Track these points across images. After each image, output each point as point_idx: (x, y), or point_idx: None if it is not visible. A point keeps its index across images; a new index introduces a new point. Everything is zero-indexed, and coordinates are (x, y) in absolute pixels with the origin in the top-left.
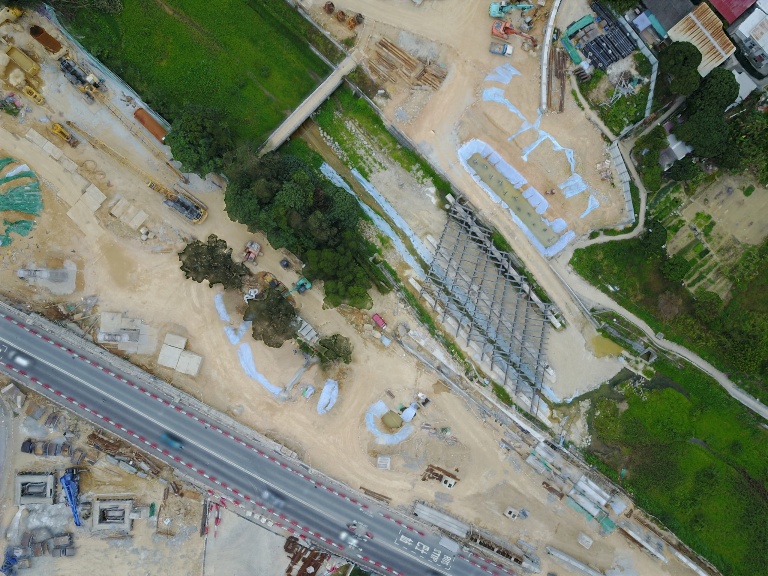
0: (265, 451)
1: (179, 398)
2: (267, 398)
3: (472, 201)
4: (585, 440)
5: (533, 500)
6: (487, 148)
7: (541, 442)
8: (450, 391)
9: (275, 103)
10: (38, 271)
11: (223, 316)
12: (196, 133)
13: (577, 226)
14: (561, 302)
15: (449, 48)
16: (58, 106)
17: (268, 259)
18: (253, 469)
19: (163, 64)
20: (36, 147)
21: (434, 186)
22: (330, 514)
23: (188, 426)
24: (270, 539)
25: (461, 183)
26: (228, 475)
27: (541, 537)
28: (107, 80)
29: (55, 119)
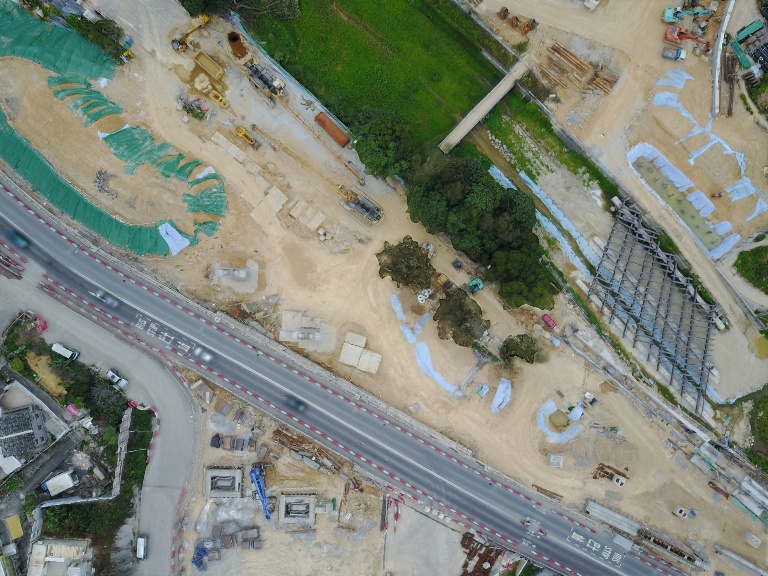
0: (441, 448)
1: (359, 395)
2: (442, 396)
3: (640, 204)
4: (748, 441)
5: (699, 499)
6: (654, 151)
7: (706, 442)
8: (617, 391)
9: (445, 107)
10: (236, 270)
11: (399, 315)
12: (387, 136)
13: (742, 229)
14: (725, 304)
15: (621, 53)
16: (240, 110)
17: (440, 260)
18: (430, 466)
19: (338, 69)
20: (221, 150)
21: (600, 189)
22: (504, 511)
23: (367, 423)
24: (447, 535)
25: (630, 186)
26: (406, 471)
27: (709, 536)
28: (288, 84)
29: (237, 122)
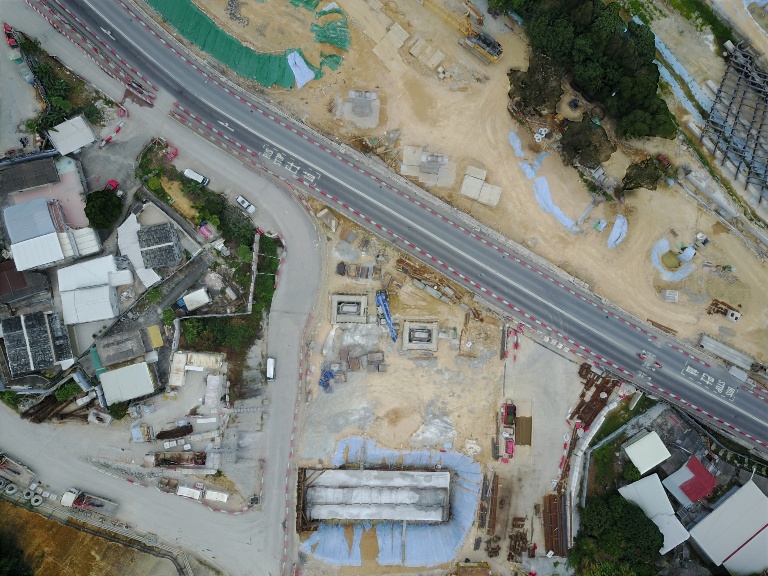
0: (559, 281)
1: (480, 227)
2: (559, 231)
3: (755, 46)
4: None
5: None
6: None
7: None
8: (729, 232)
9: None
10: (368, 92)
11: (517, 152)
12: None
13: None
14: None
15: None
16: None
17: None
18: (548, 298)
19: None
20: None
21: (712, 34)
22: (621, 343)
23: (487, 255)
24: (564, 365)
25: (744, 28)
26: (525, 303)
27: None
28: None
29: None
